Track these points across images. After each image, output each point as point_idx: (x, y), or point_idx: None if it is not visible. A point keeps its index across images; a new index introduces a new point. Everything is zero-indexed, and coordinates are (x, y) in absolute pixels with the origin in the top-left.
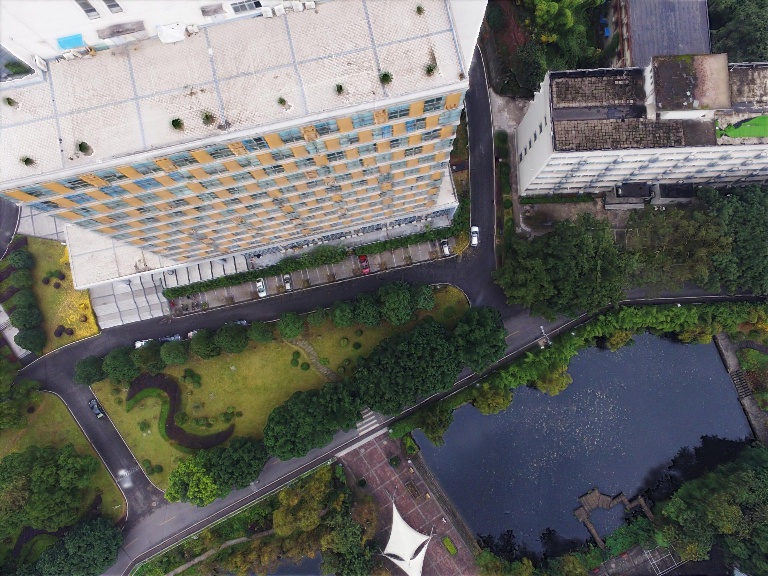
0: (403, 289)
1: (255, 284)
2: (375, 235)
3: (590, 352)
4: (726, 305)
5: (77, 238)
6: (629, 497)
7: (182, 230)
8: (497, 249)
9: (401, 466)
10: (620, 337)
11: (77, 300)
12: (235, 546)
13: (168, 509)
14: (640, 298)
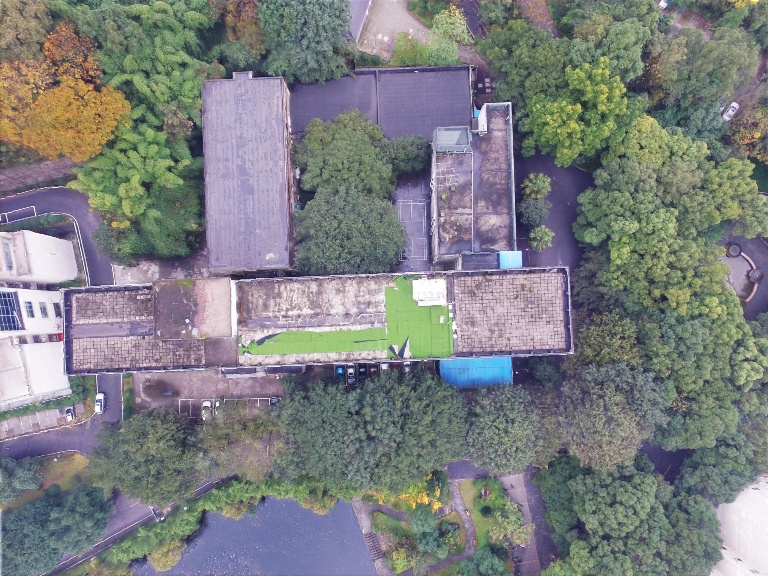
0: None
1: None
2: None
3: None
4: None
5: None
6: None
7: None
8: (123, 416)
9: None
10: (229, 513)
11: None
12: None
13: None
14: None
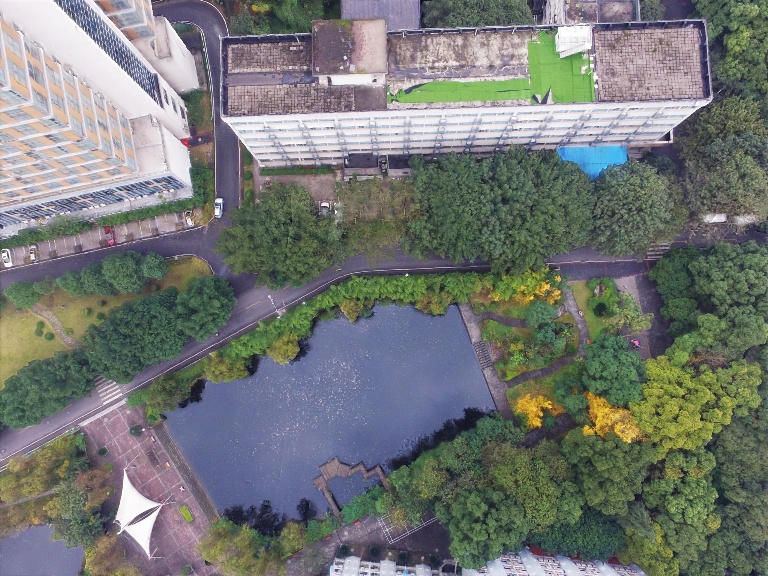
0: (126, 257)
1: None
2: (118, 206)
3: (336, 323)
4: (454, 275)
5: None
6: (370, 466)
7: None
8: None
9: (143, 435)
10: (348, 306)
11: None
12: None
13: None
14: (378, 269)
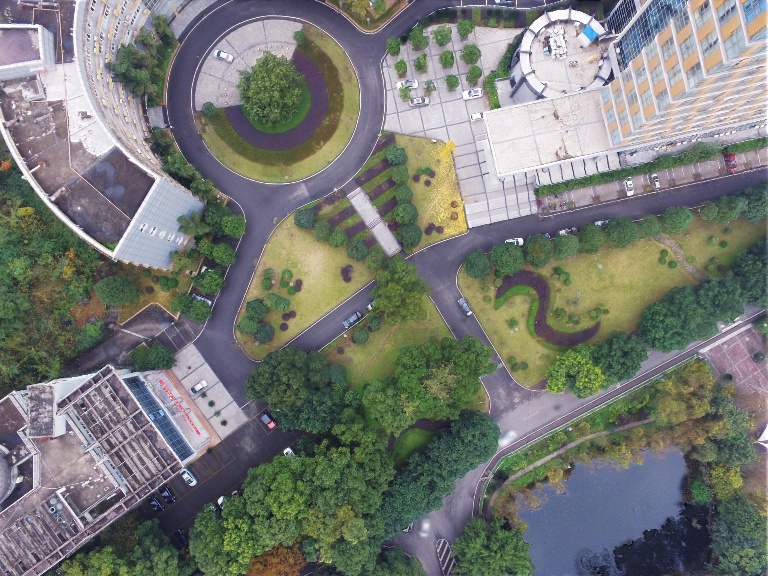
0: None
1: (622, 183)
2: (746, 133)
3: None
4: None
5: (497, 125)
6: None
7: (725, 93)
8: None
9: (763, 361)
10: None
11: (448, 198)
12: (593, 440)
13: (530, 405)
14: None
